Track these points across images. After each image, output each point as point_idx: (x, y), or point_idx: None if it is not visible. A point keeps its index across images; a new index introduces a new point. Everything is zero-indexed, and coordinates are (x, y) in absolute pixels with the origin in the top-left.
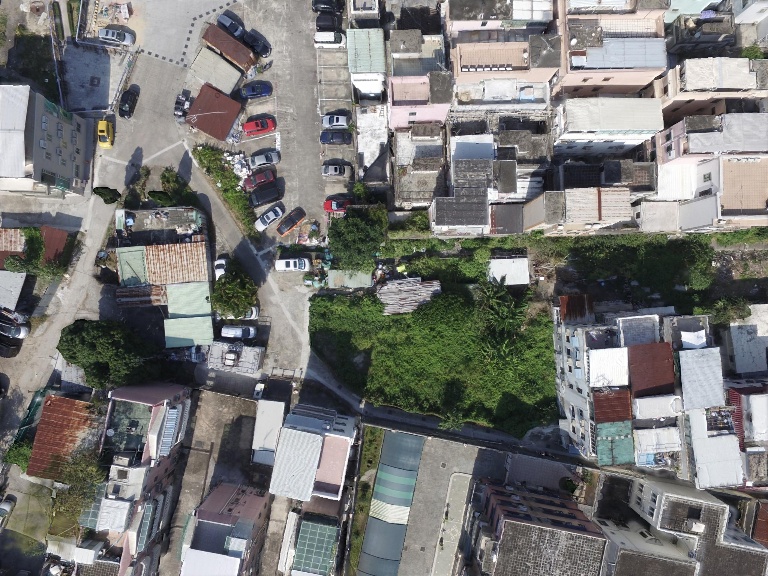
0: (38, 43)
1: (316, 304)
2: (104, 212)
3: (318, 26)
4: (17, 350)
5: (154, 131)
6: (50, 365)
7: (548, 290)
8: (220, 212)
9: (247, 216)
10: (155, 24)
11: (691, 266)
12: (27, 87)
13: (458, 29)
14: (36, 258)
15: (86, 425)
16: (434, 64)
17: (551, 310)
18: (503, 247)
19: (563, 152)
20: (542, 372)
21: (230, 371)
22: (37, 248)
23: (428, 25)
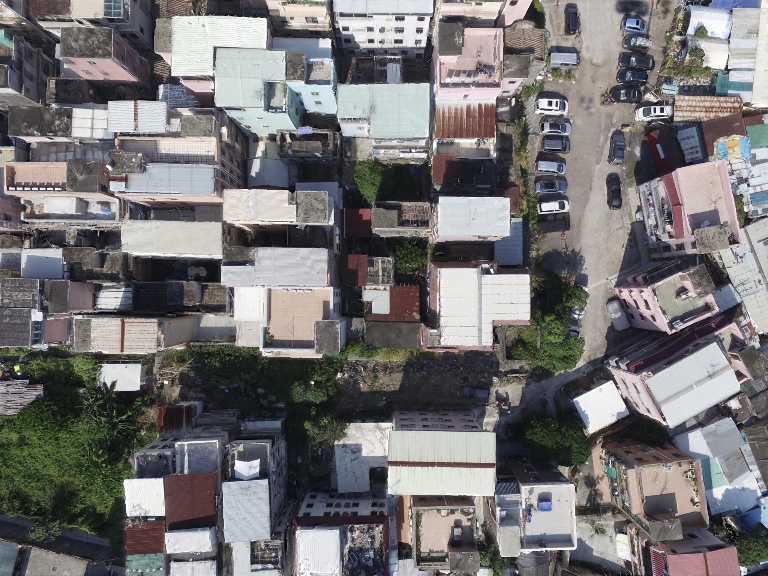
0: None
1: None
2: None
3: None
4: None
5: None
6: None
7: (173, 394)
8: None
9: None
10: None
11: (295, 382)
12: None
13: (33, 140)
14: None
15: None
16: None
17: None
18: None
19: (176, 259)
20: None
21: None
22: None
23: None
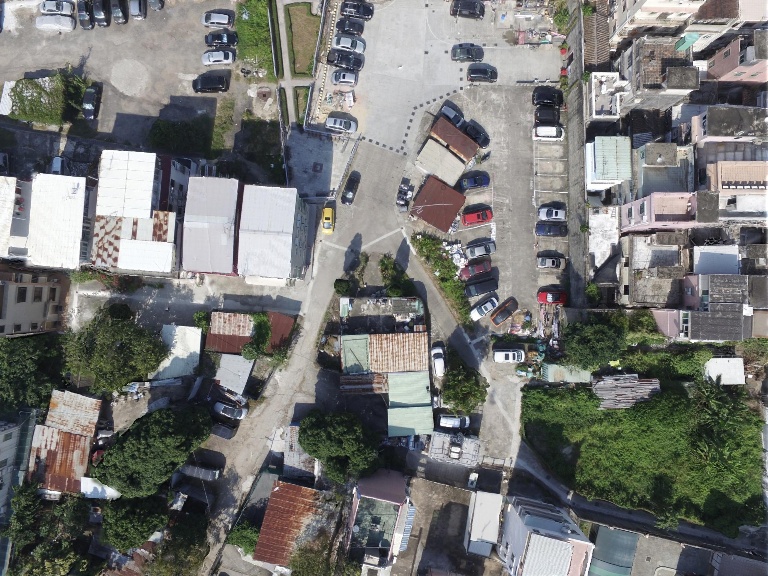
0: (263, 128)
1: (531, 396)
2: (322, 296)
3: (539, 120)
4: (236, 431)
5: (373, 218)
6: (266, 446)
7: (756, 388)
8: (436, 300)
9: (464, 306)
10: (377, 112)
11: None
12: (294, 190)
13: (706, 140)
14: (262, 343)
15: (311, 511)
16: (679, 173)
17: (763, 410)
18: (715, 345)
19: None
20: (749, 470)
21: (452, 463)
22: (264, 333)
23: (658, 127)
